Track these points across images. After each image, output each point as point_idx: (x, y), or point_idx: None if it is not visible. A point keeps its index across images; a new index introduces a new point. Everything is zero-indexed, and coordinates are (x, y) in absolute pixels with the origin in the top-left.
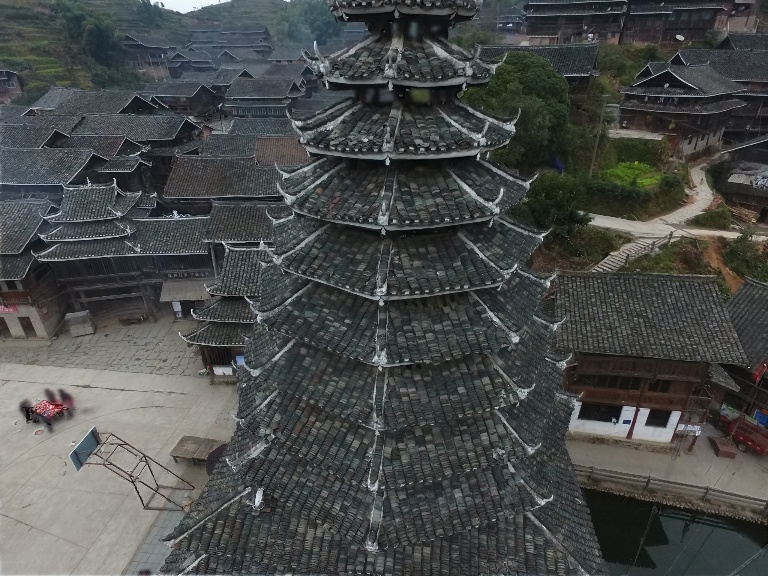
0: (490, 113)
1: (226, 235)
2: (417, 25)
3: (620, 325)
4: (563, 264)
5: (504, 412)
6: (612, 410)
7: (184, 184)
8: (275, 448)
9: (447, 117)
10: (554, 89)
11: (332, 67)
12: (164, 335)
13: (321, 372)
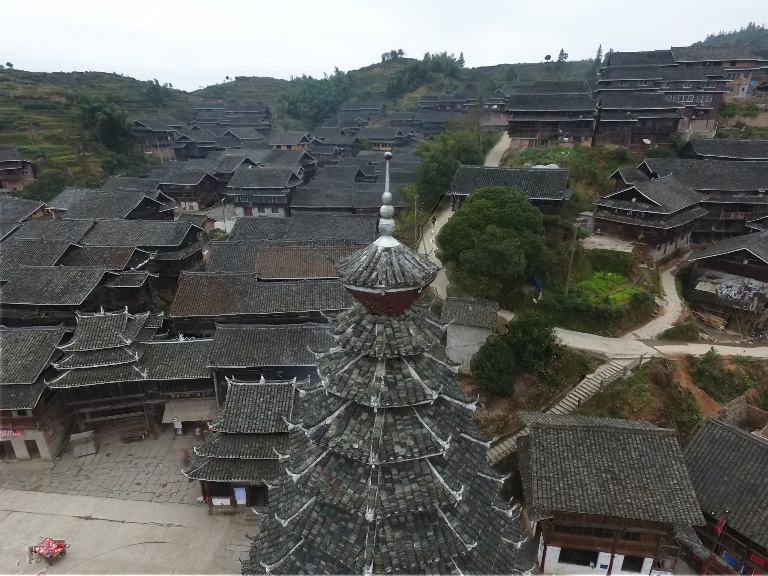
0: (455, 396)
1: (228, 360)
2: None
3: (590, 481)
4: (543, 388)
5: None
6: (589, 555)
7: (190, 302)
8: None
9: (420, 418)
10: (529, 222)
11: (331, 382)
12: (164, 454)
13: None
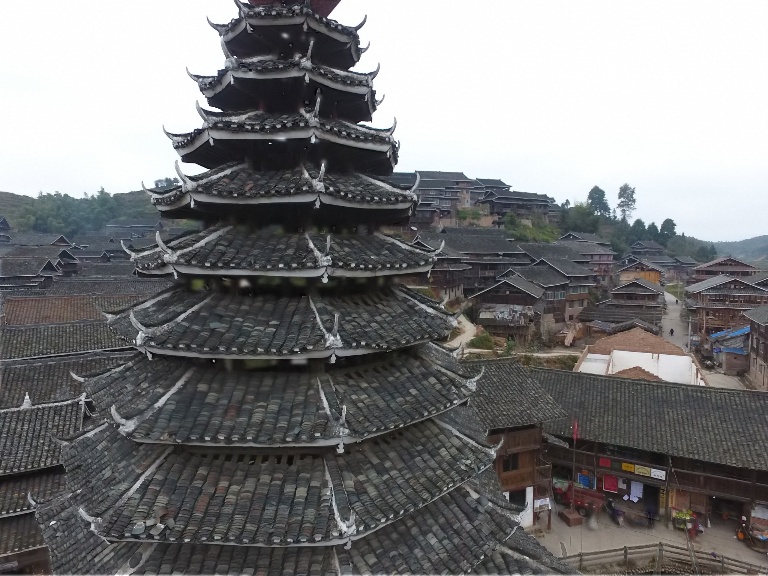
0: None
1: None
2: (313, 54)
3: None
4: None
5: (452, 424)
6: None
7: None
8: (150, 569)
9: (352, 125)
10: None
11: (238, 65)
12: None
13: (238, 403)
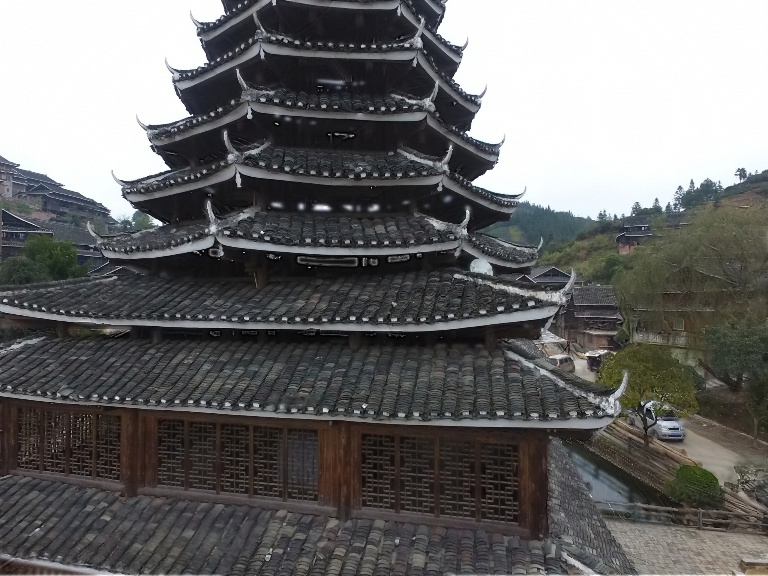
0: None
1: None
2: None
3: None
4: None
5: None
6: None
7: None
8: None
9: None
10: None
11: None
12: None
13: None
